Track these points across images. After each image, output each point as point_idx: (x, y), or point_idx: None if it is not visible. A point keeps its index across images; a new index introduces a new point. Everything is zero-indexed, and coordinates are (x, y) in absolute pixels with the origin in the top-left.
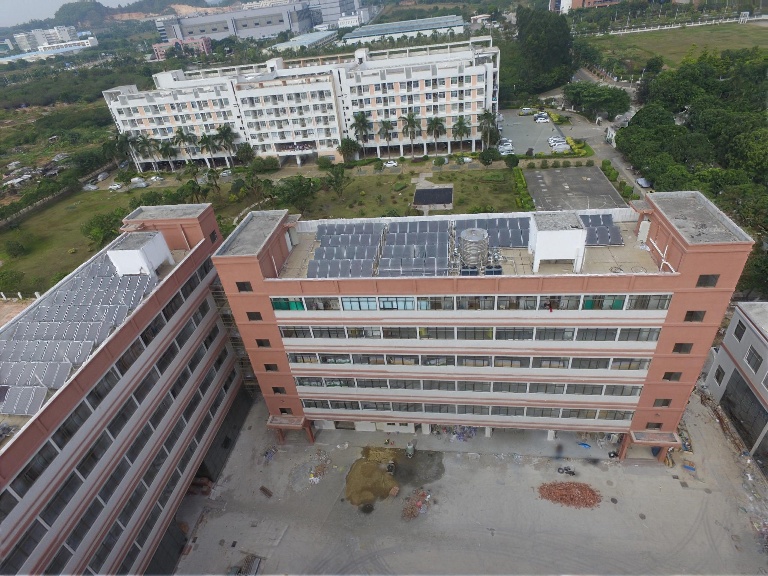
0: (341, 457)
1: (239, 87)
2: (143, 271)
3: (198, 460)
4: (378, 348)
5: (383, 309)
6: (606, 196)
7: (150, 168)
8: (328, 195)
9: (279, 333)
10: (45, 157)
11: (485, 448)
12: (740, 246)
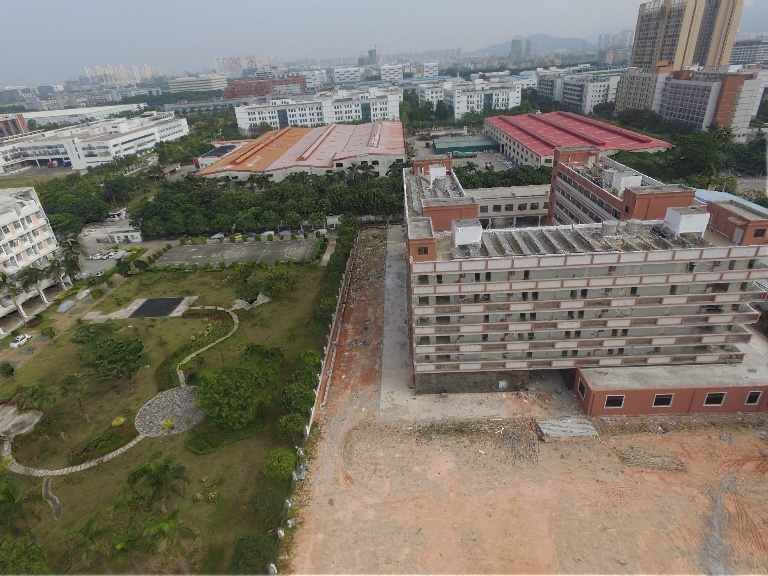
0: None
1: None
2: None
3: None
4: None
5: None
6: (228, 247)
7: None
8: None
9: None
10: None
11: None
12: None
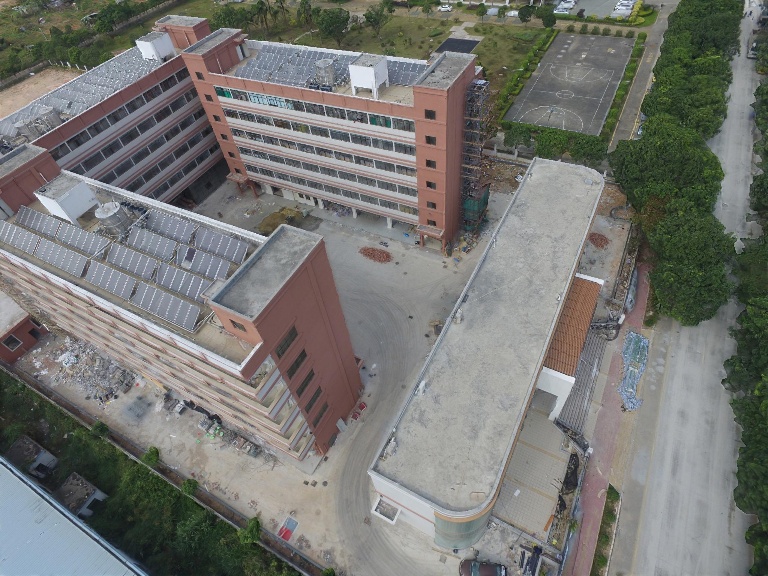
0: (267, 209)
1: None
2: (154, 57)
3: (184, 185)
4: (273, 133)
5: (271, 105)
6: (610, 71)
7: None
8: (373, 32)
9: (223, 113)
10: None
11: (348, 223)
12: (439, 91)
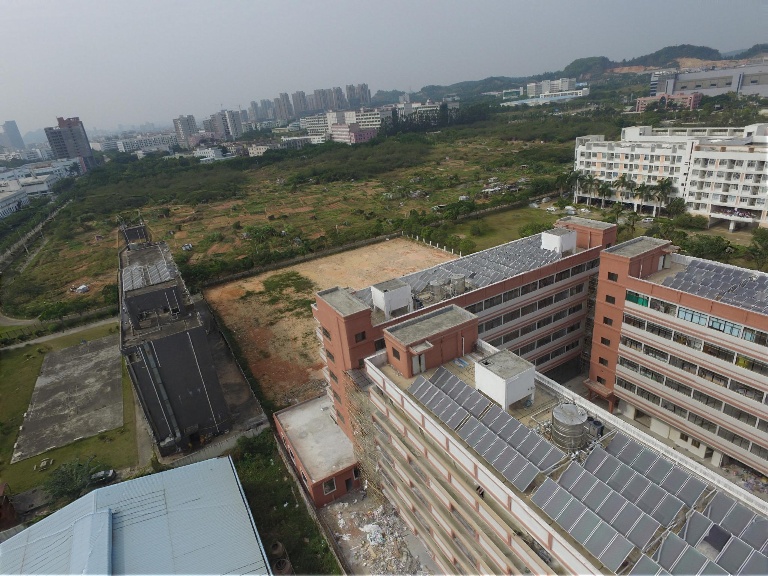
0: None
1: (698, 148)
2: (556, 250)
3: None
4: (694, 358)
5: (711, 327)
6: None
7: (584, 202)
8: (746, 265)
9: (622, 318)
10: (513, 178)
11: None
12: None
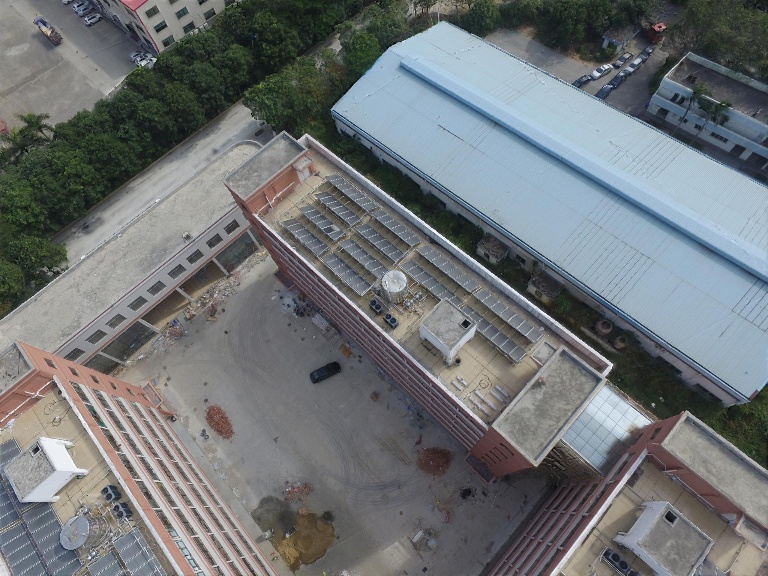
0: None
1: None
2: None
3: None
4: (227, 567)
5: (198, 568)
6: None
7: None
8: None
9: None
10: None
11: (225, 490)
12: (22, 346)
